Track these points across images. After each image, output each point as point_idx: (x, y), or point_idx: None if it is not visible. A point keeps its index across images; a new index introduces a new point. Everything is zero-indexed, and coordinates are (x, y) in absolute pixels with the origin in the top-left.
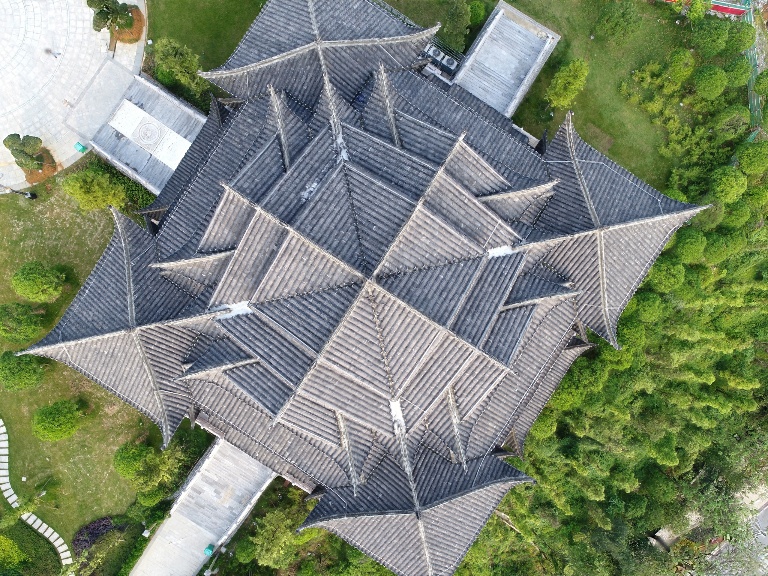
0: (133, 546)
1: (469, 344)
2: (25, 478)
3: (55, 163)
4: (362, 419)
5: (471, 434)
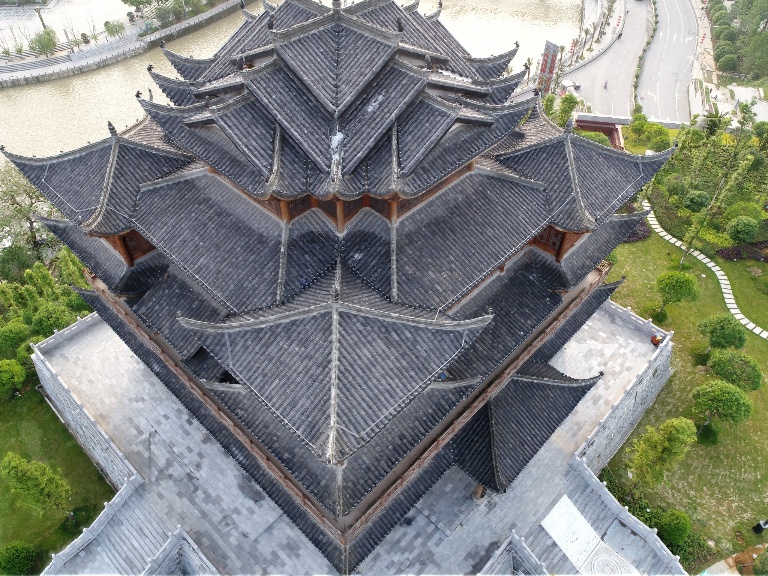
0: None
1: None
2: (703, 276)
3: (738, 569)
4: None
5: None
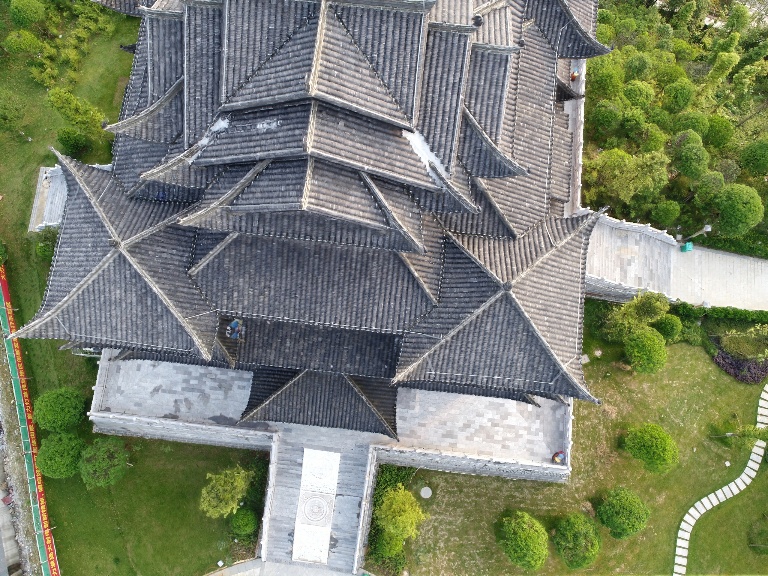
0: (726, 322)
1: None
2: (726, 463)
3: None
4: None
5: None
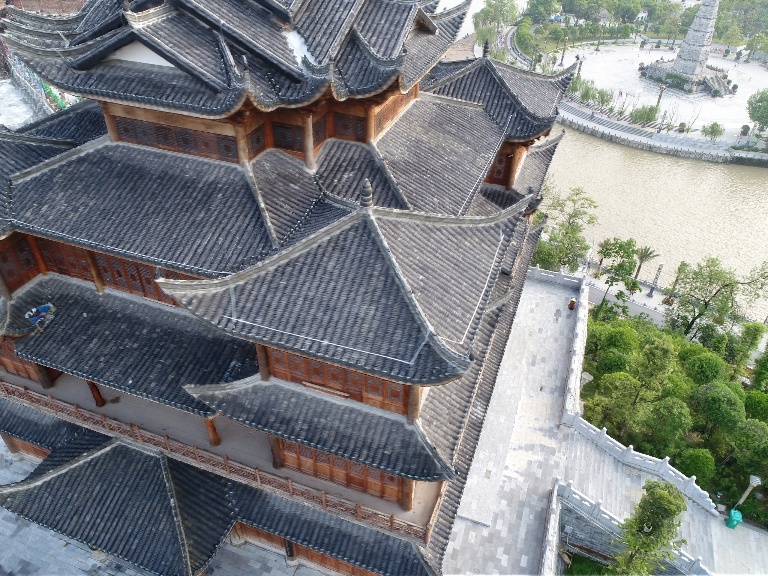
0: None
1: None
2: None
3: None
4: None
5: None
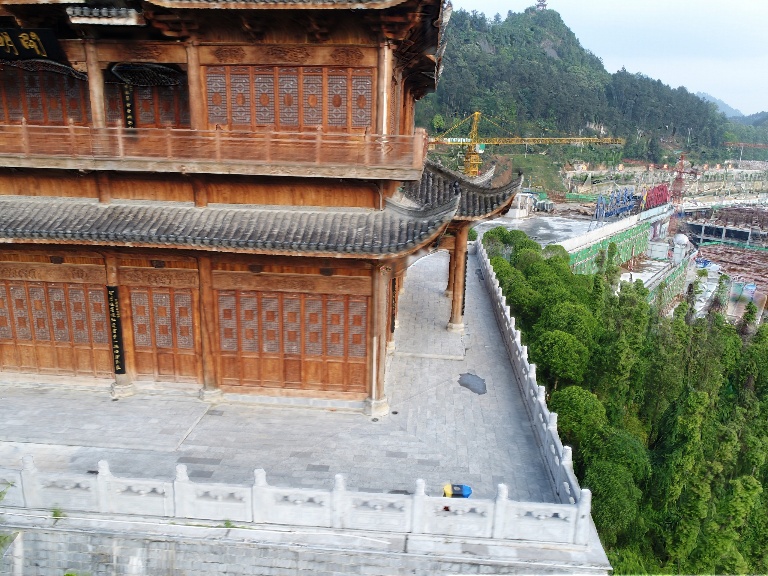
0: None
1: None
2: None
3: None
4: None
5: None
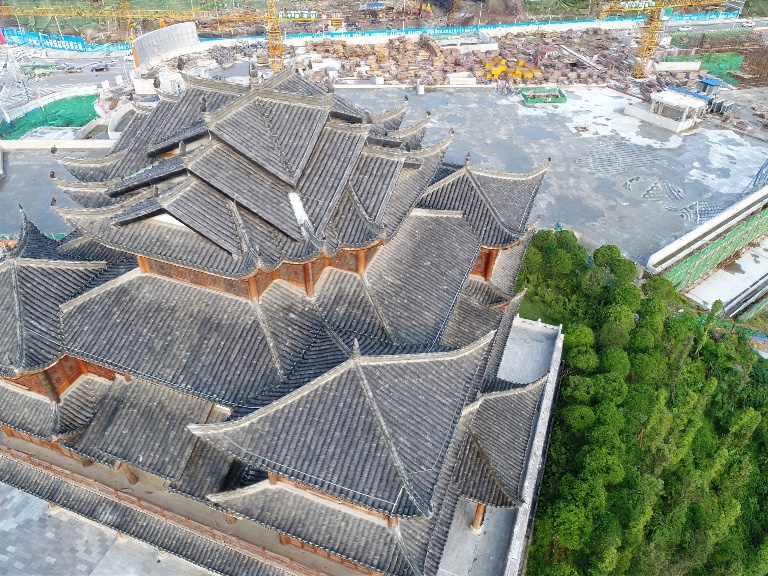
0: None
1: (354, 124)
2: None
3: None
4: (262, 210)
5: (407, 319)
